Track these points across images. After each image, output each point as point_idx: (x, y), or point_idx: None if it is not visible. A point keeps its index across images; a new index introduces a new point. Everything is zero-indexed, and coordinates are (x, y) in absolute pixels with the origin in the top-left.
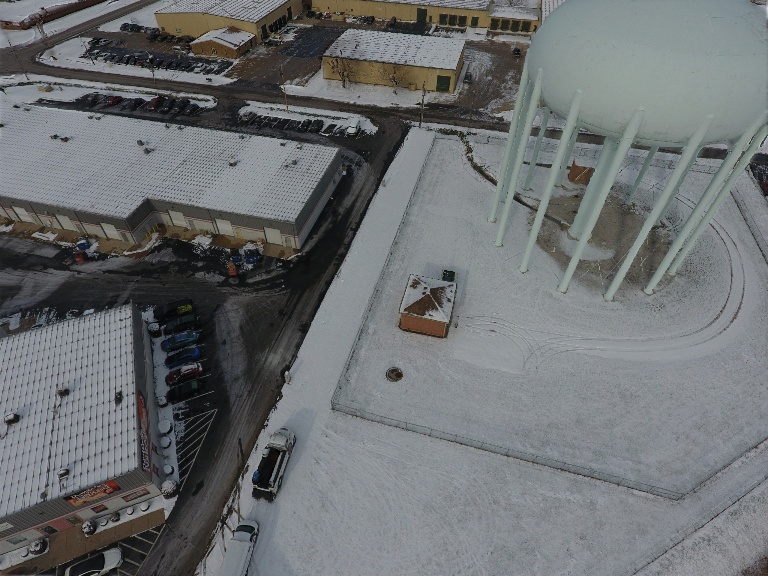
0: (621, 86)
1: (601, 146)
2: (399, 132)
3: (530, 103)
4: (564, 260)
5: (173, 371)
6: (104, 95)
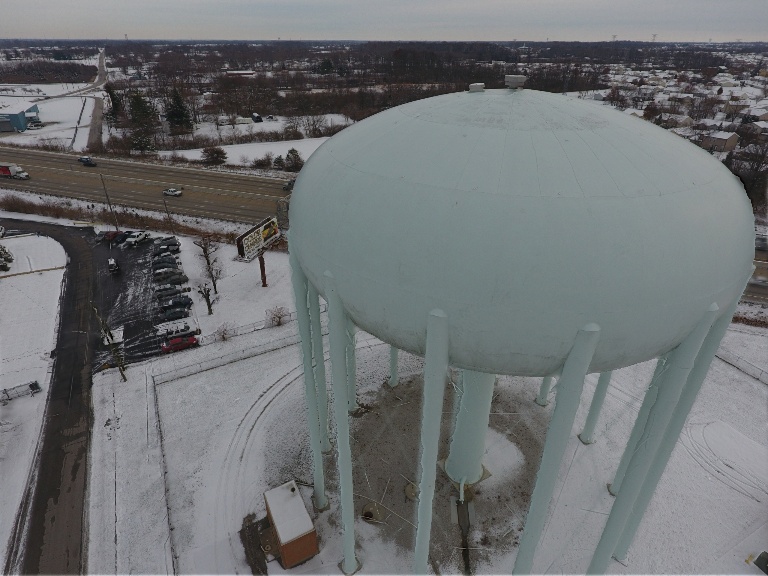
0: None
1: (95, 574)
2: None
3: None
4: (539, 459)
5: None
6: None
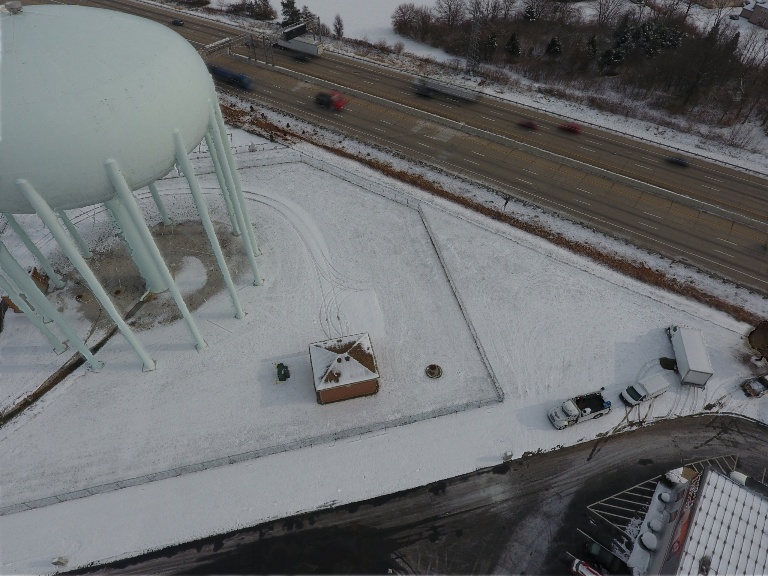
0: (191, 96)
1: None
2: None
3: (128, 202)
4: (213, 288)
5: None
6: None
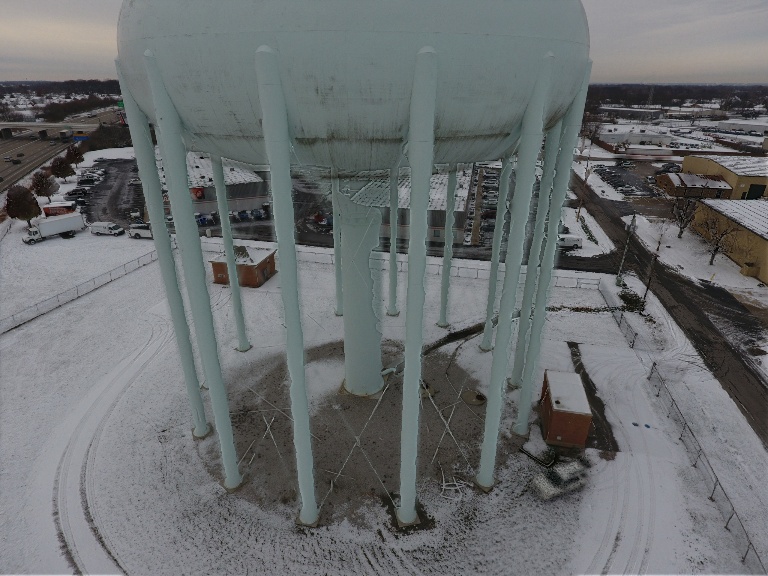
0: None
1: None
2: (590, 267)
3: None
4: None
5: (236, 215)
6: (537, 176)
